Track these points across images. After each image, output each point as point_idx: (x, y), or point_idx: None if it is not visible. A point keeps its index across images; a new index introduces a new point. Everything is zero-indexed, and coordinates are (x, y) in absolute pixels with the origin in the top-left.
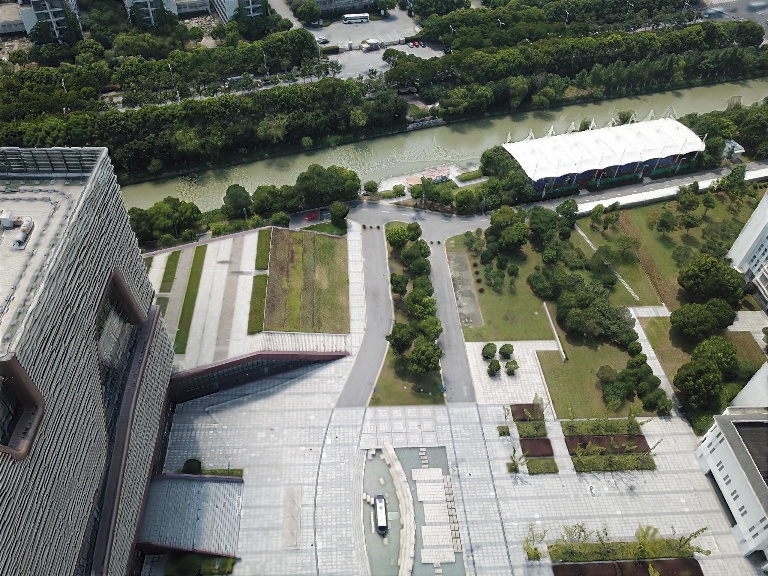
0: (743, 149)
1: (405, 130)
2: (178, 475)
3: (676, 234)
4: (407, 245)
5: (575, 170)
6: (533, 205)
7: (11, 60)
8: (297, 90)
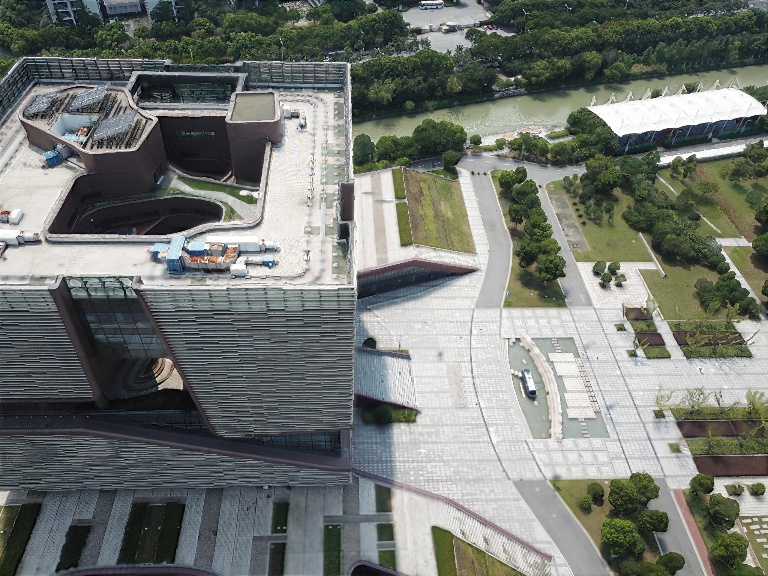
0: None
1: (492, 98)
2: (363, 348)
3: (746, 183)
4: (513, 188)
5: (654, 128)
6: (617, 158)
7: (136, 35)
8: (400, 60)
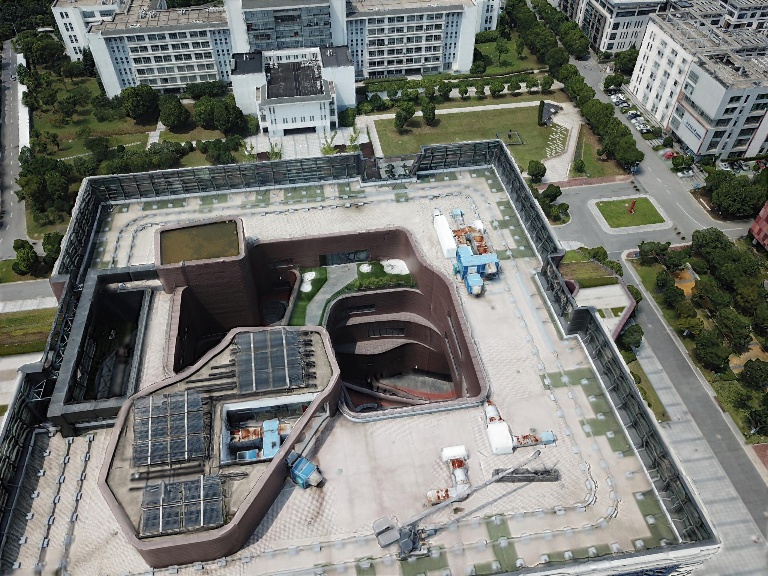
0: None
1: None
2: None
3: (75, 117)
4: None
5: None
6: (3, 184)
7: None
8: None
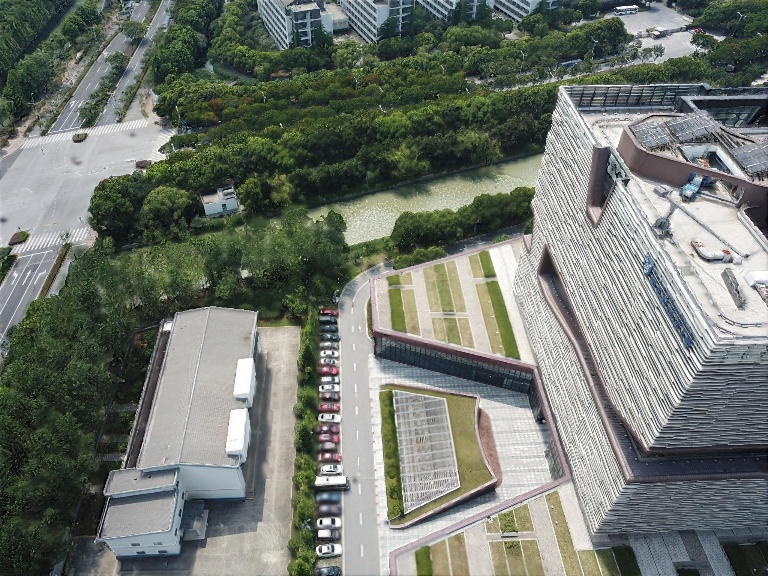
0: None
1: None
2: None
3: None
4: None
5: None
6: None
7: (368, 52)
8: (662, 68)
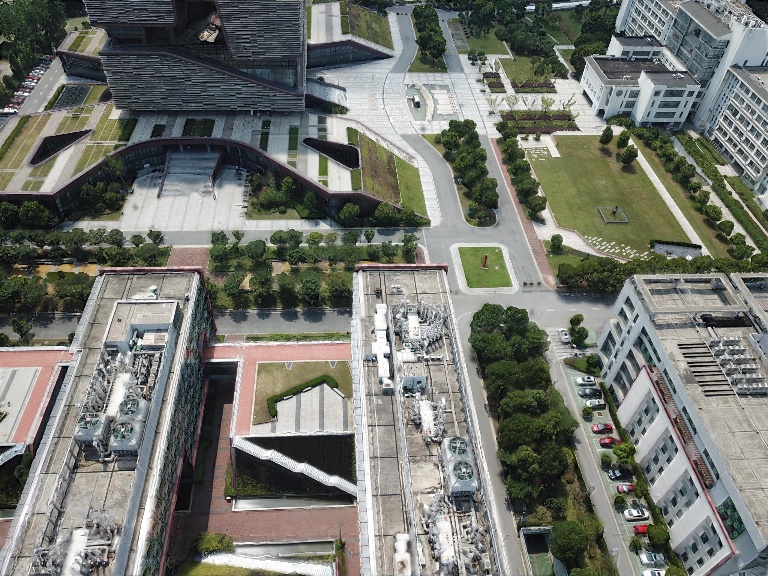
0: None
1: None
2: None
3: None
4: None
5: None
6: None
7: None
8: None
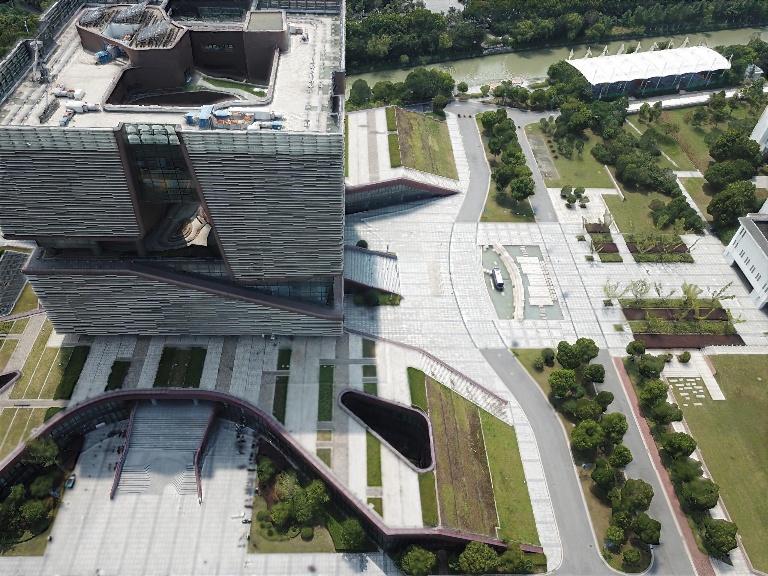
0: (762, 71)
1: (481, 55)
2: (356, 247)
3: (707, 127)
4: None
5: (625, 79)
6: None
7: None
8: (397, 17)
